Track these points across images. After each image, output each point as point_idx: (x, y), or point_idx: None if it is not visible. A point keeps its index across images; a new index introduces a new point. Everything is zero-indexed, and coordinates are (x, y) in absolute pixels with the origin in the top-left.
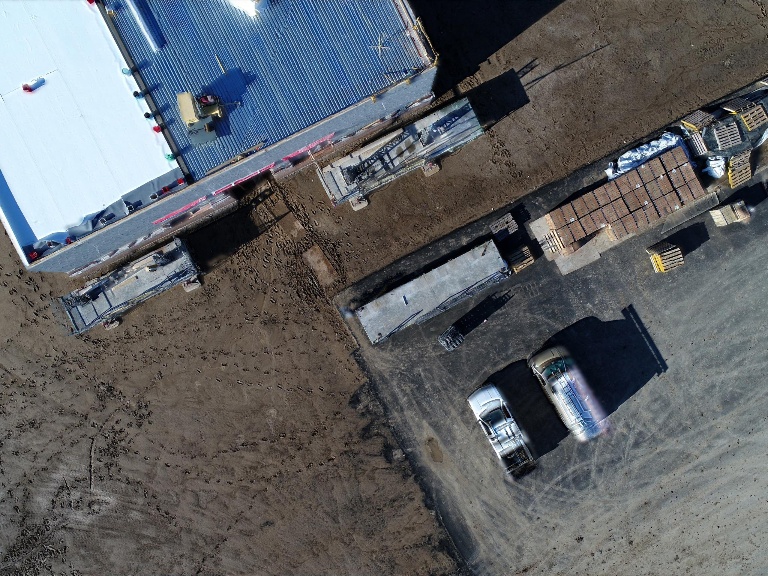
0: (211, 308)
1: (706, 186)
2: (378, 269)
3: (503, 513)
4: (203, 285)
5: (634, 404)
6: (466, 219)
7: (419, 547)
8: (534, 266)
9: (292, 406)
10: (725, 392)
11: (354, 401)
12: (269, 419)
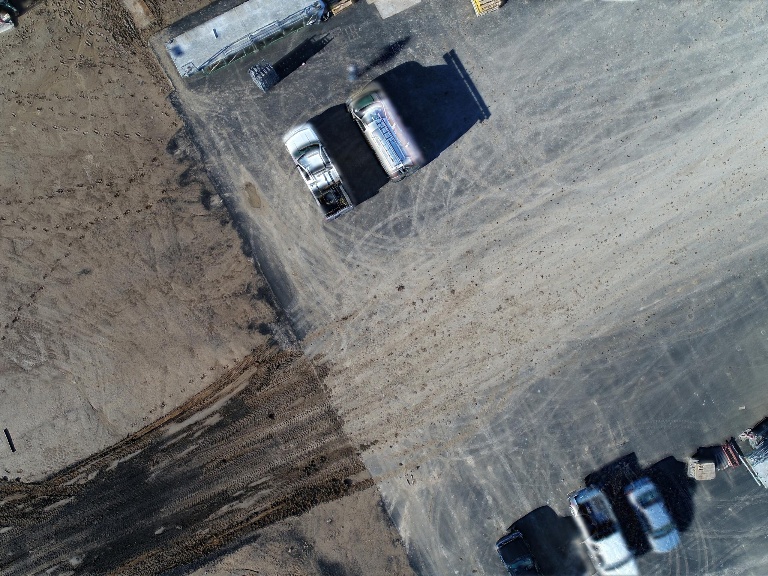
0: (25, 50)
1: None
2: (194, 11)
3: (322, 260)
4: (17, 27)
5: (456, 151)
6: None
7: (238, 296)
8: (353, 9)
9: (109, 152)
10: (549, 139)
11: (171, 146)
12: (85, 165)
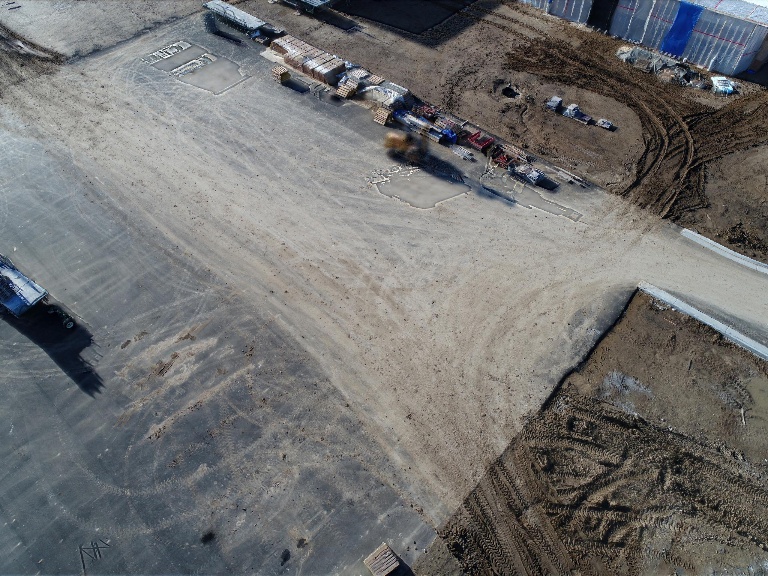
0: None
1: (332, 85)
2: None
3: None
4: None
5: None
6: (277, 26)
7: None
8: None
9: None
10: (208, 117)
11: (172, 17)
12: (158, 2)
